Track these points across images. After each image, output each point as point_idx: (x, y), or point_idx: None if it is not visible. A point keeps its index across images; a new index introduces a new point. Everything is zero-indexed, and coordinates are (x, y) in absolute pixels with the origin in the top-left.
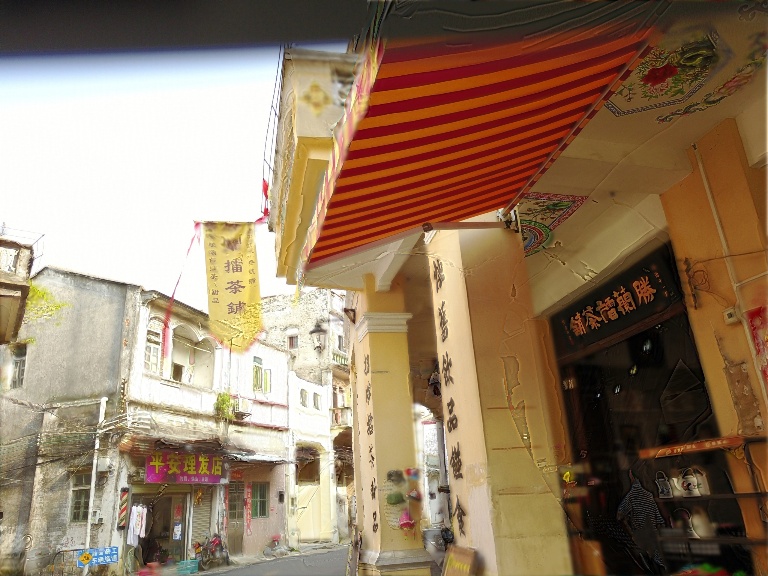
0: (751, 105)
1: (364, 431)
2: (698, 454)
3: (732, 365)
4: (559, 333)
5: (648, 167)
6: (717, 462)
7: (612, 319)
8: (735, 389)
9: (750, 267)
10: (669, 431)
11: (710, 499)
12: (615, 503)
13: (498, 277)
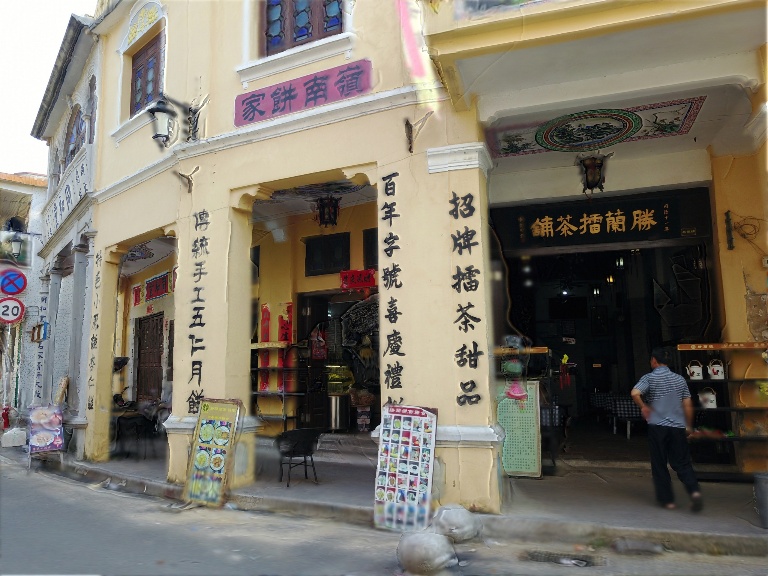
0: None
1: (436, 284)
2: (742, 351)
3: (754, 294)
4: (503, 227)
5: (753, 136)
6: (752, 357)
7: (592, 232)
8: (752, 310)
9: None
10: (673, 332)
11: (728, 381)
12: (629, 382)
13: None
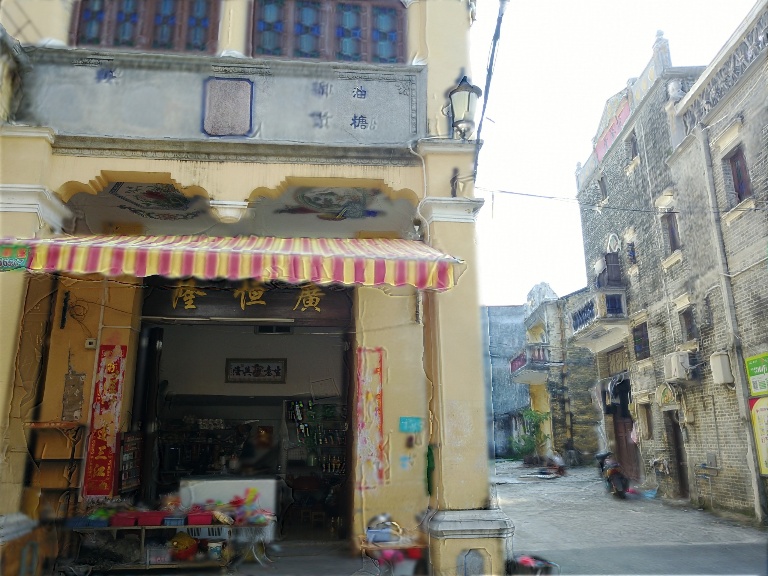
0: (164, 230)
1: None
2: (33, 430)
3: (74, 374)
4: None
5: None
6: (45, 437)
7: None
8: (69, 390)
9: (119, 320)
10: None
11: None
12: None
13: (52, 289)
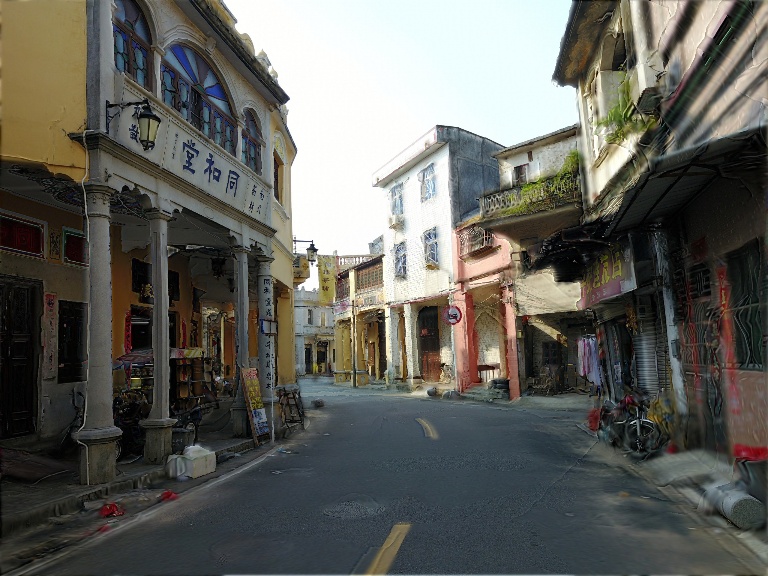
0: None
1: None
2: None
3: None
4: None
5: None
6: None
7: None
8: None
9: None
10: None
11: None
12: None
13: None
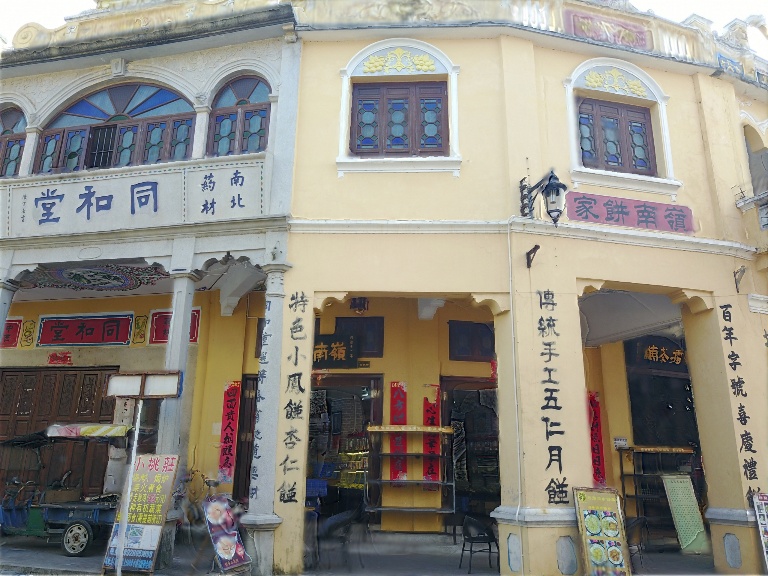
0: None
1: (767, 398)
2: None
3: None
4: (625, 348)
5: None
6: None
7: None
8: None
9: None
10: None
11: None
12: None
13: None
